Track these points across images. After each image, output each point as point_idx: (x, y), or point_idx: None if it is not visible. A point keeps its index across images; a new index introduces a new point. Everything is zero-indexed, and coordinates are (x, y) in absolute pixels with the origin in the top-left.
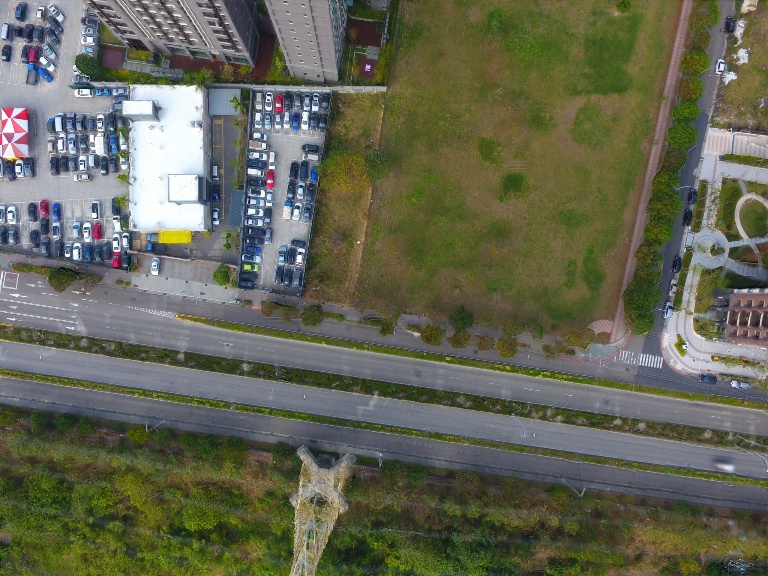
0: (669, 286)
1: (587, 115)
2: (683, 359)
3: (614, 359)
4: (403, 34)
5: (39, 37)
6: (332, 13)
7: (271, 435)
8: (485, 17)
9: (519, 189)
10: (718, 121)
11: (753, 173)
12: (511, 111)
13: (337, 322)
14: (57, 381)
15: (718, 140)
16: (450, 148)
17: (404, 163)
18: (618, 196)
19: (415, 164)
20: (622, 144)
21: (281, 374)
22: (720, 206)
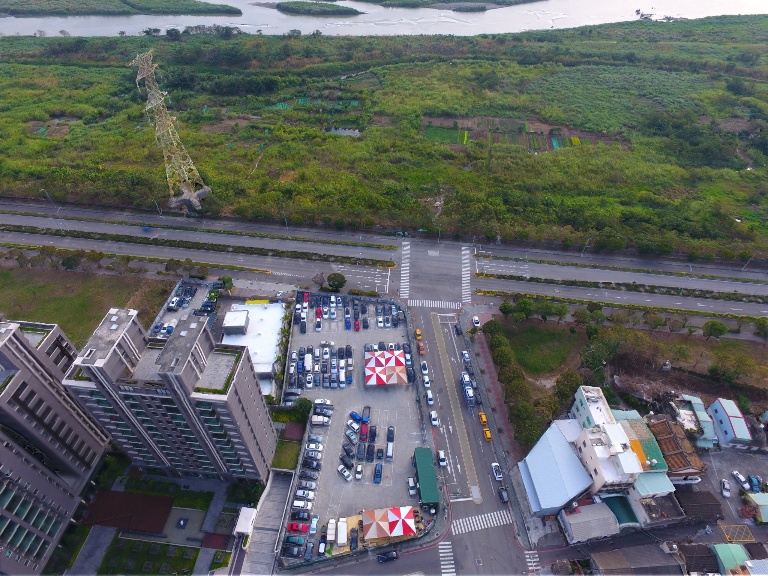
0: None
1: None
2: None
3: None
4: None
5: None
6: None
7: (224, 224)
8: None
9: None
10: None
11: None
12: None
13: (163, 271)
14: (349, 243)
15: None
16: None
17: None
18: None
19: None
20: None
21: (208, 246)
22: None
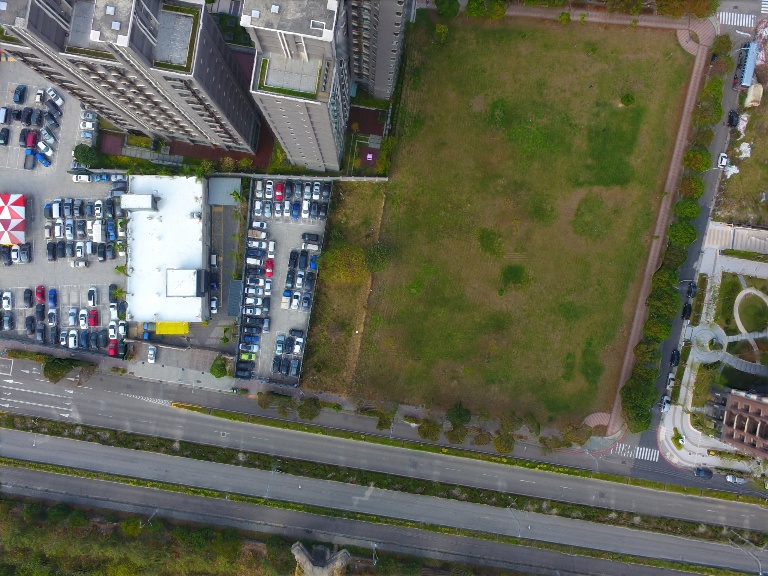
0: (667, 380)
1: (589, 207)
2: (679, 453)
3: (610, 452)
4: (406, 123)
5: (37, 121)
6: (335, 128)
7: (266, 524)
8: (488, 107)
9: (519, 281)
10: (719, 215)
11: (753, 267)
12: (513, 205)
13: (334, 412)
14: (50, 469)
15: (719, 234)
16: (451, 239)
17: (404, 253)
18: (618, 289)
19: (415, 254)
20: (623, 236)
21: (277, 464)
22: (719, 300)
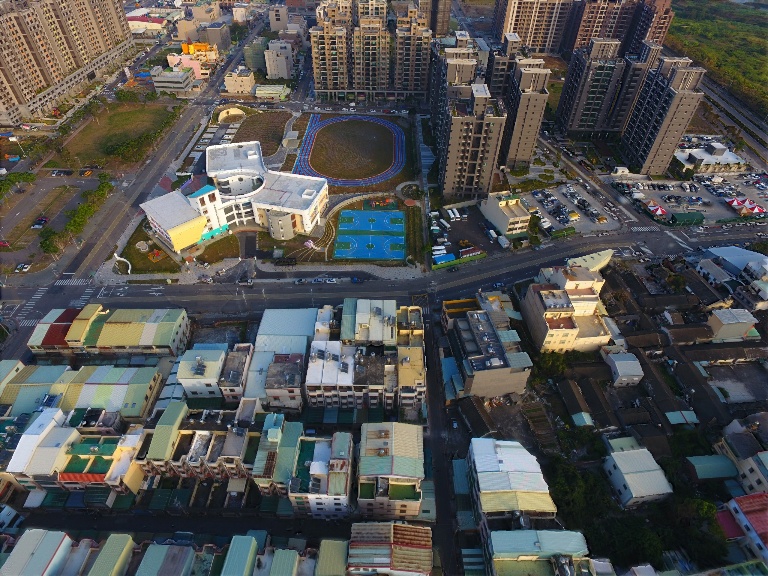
0: None
1: None
2: None
3: None
4: None
5: None
6: None
7: None
8: None
9: None
10: None
11: None
12: None
13: (723, 132)
14: None
15: None
16: None
17: None
18: None
19: None
20: None
21: None
22: None
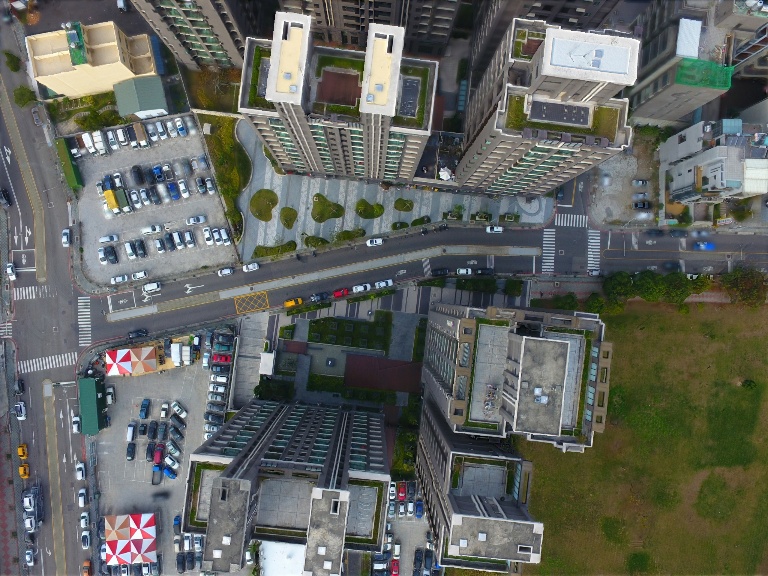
0: None
1: (711, 488)
2: None
3: None
4: None
5: (163, 437)
6: None
7: None
8: None
9: (645, 569)
10: None
11: None
12: (639, 503)
13: None
14: None
15: None
16: (575, 530)
17: None
18: (745, 572)
19: None
20: (748, 518)
21: None
22: None
